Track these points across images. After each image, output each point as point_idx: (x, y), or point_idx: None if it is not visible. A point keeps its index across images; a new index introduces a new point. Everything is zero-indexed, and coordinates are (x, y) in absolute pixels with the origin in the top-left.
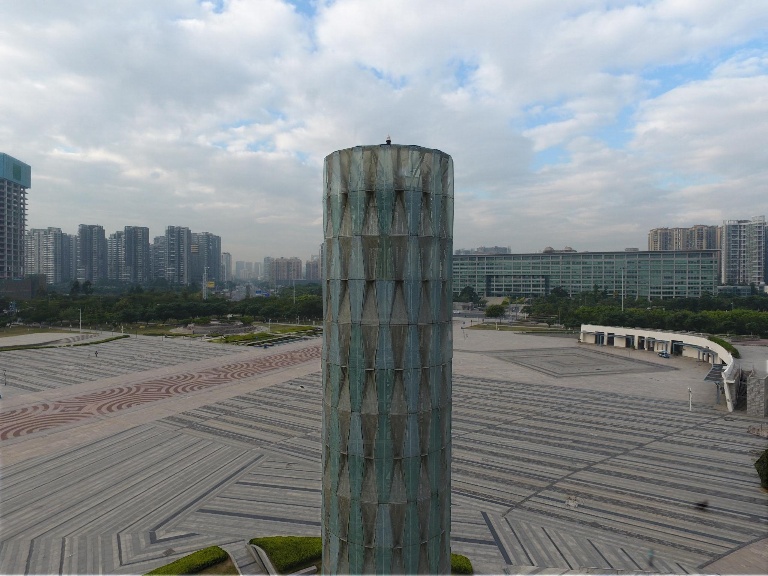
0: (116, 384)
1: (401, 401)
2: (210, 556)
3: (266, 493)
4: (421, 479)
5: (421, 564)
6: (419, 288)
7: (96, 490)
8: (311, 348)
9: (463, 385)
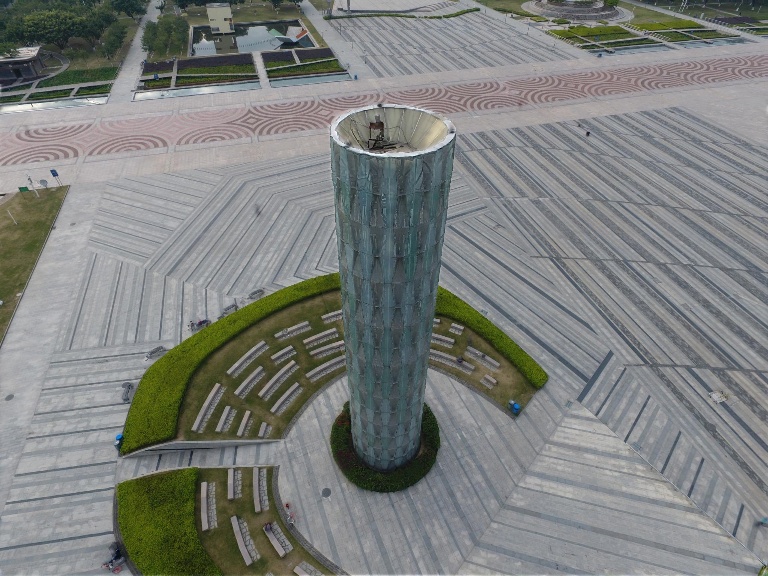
0: (433, 82)
1: None
2: None
3: (461, 245)
4: (376, 356)
5: (376, 389)
6: (371, 260)
7: None
8: (654, 69)
9: None
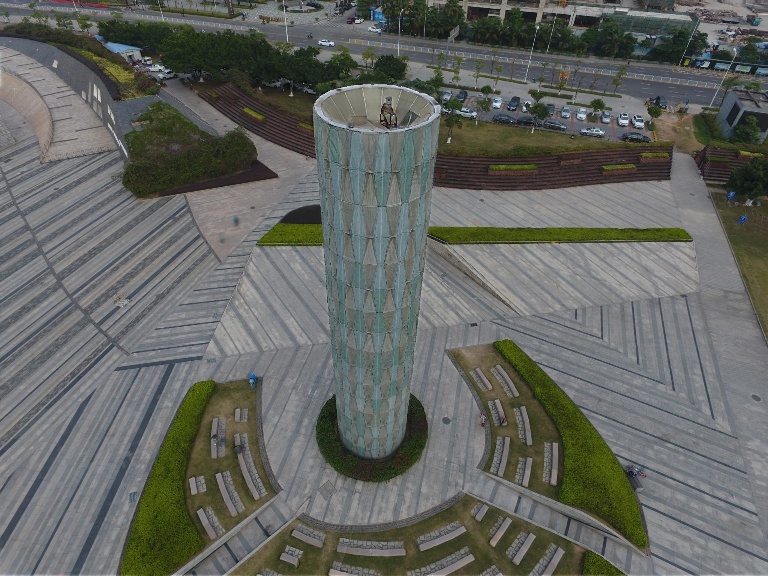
0: None
1: None
2: None
3: None
4: None
5: None
6: None
7: None
8: None
9: None
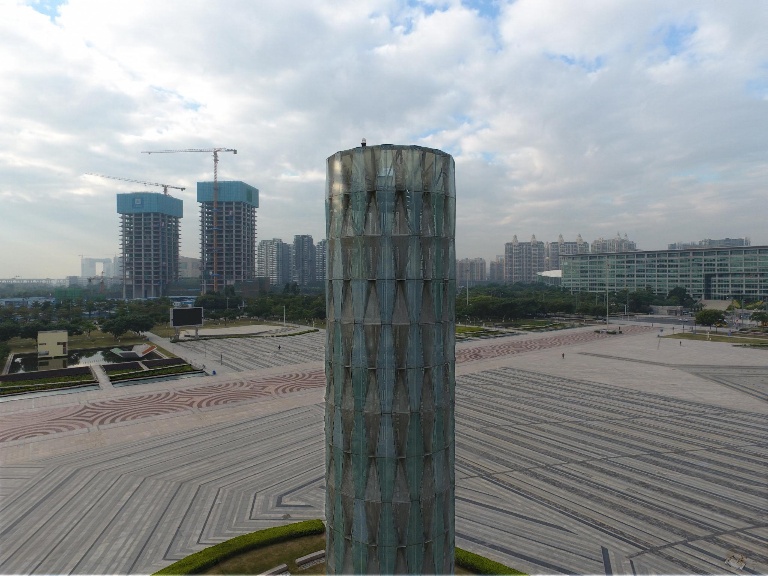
0: (295, 370)
1: (375, 400)
2: (309, 527)
3: None
4: (398, 482)
5: (399, 568)
6: (393, 288)
7: (253, 455)
8: (472, 349)
9: (634, 402)
